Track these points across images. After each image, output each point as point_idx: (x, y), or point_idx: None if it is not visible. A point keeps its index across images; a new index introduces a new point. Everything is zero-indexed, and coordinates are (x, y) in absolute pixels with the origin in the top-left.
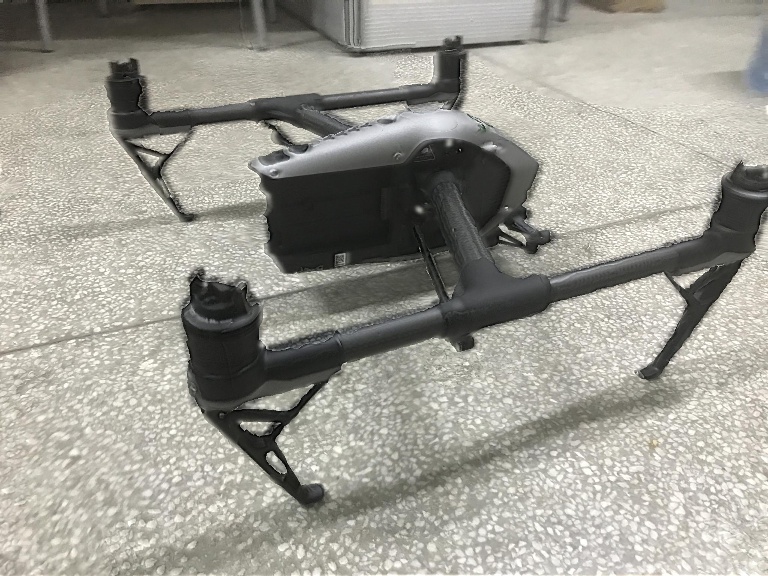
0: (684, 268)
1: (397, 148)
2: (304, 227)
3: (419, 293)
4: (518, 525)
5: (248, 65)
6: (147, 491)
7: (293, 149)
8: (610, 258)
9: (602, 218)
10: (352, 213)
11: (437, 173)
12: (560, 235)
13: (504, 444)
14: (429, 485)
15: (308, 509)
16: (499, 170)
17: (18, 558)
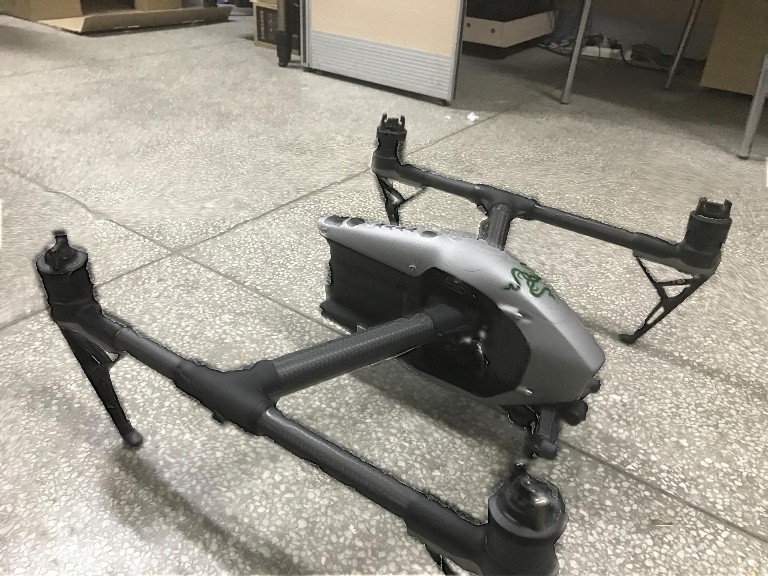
0: (411, 529)
1: (416, 261)
2: (348, 288)
3: (423, 412)
4: (145, 574)
5: (707, 171)
6: (114, 369)
7: (350, 220)
8: (660, 555)
9: (759, 524)
10: (385, 300)
11: (441, 304)
12: (659, 490)
13: (241, 537)
14: (170, 501)
15: (122, 443)
16: (524, 344)
17: (51, 348)
